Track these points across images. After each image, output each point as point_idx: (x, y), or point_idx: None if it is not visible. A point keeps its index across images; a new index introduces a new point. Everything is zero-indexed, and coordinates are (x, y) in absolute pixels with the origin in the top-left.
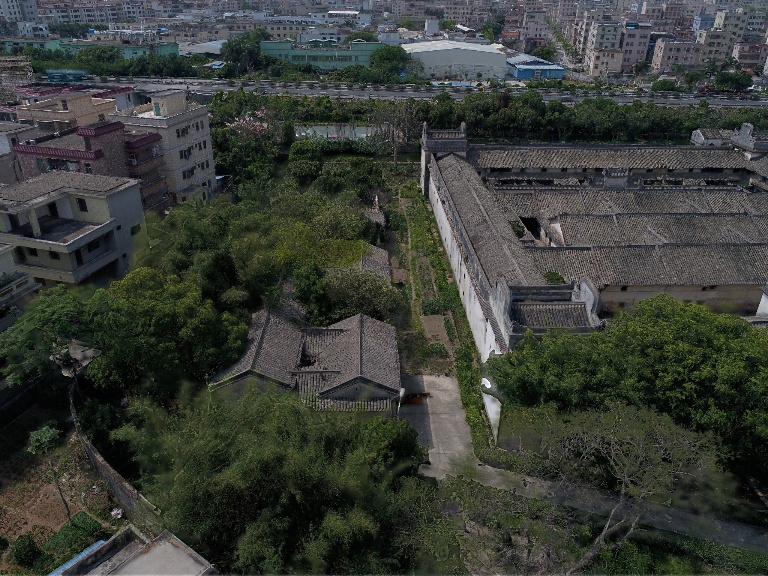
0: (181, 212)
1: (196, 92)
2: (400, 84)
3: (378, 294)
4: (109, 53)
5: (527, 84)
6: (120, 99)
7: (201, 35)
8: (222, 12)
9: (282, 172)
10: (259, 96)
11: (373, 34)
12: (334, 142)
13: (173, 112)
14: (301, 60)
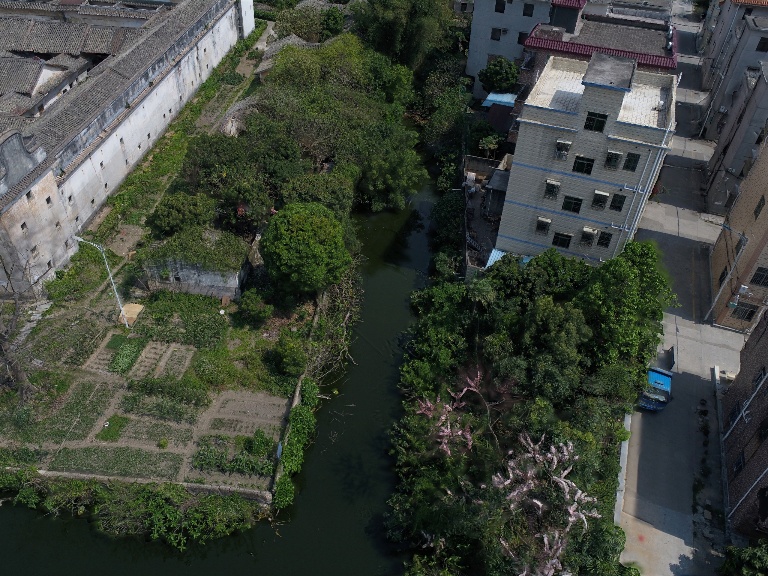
0: (432, 2)
1: None
2: None
3: None
4: None
5: None
6: None
7: None
8: None
9: (368, 492)
10: None
11: None
12: None
13: None
14: None
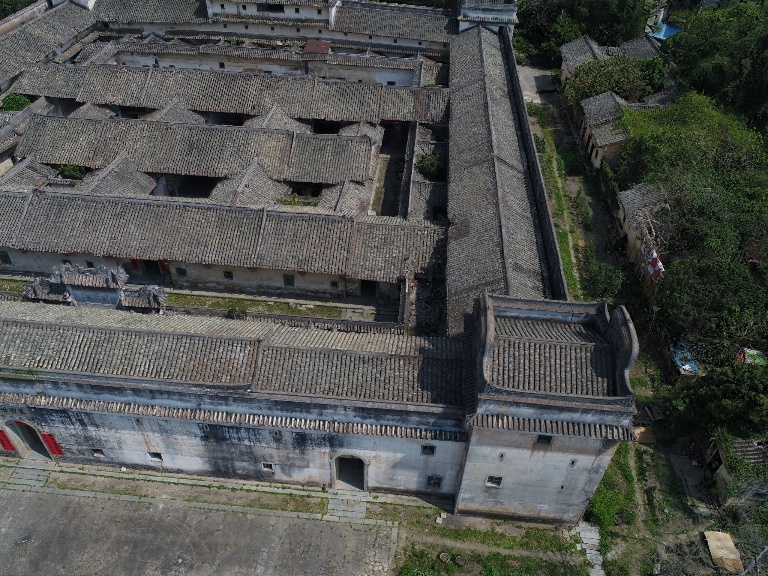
0: None
1: None
2: None
3: None
4: None
5: None
6: None
7: None
8: None
9: None
10: None
11: None
12: None
13: None
14: None
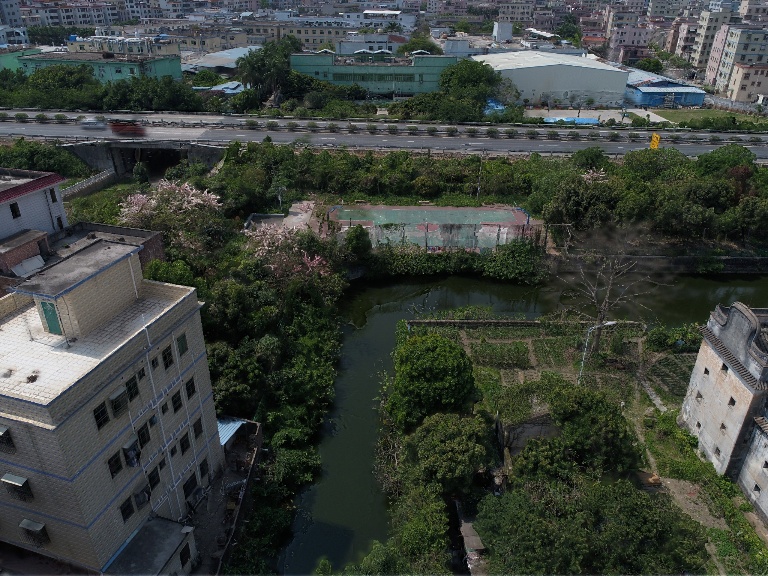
0: None
1: (197, 143)
2: (501, 123)
3: None
4: (76, 75)
5: (664, 116)
6: (31, 202)
7: (212, 42)
8: (239, 11)
9: (355, 341)
10: (296, 149)
11: (435, 42)
12: (438, 255)
13: (99, 318)
14: (345, 80)
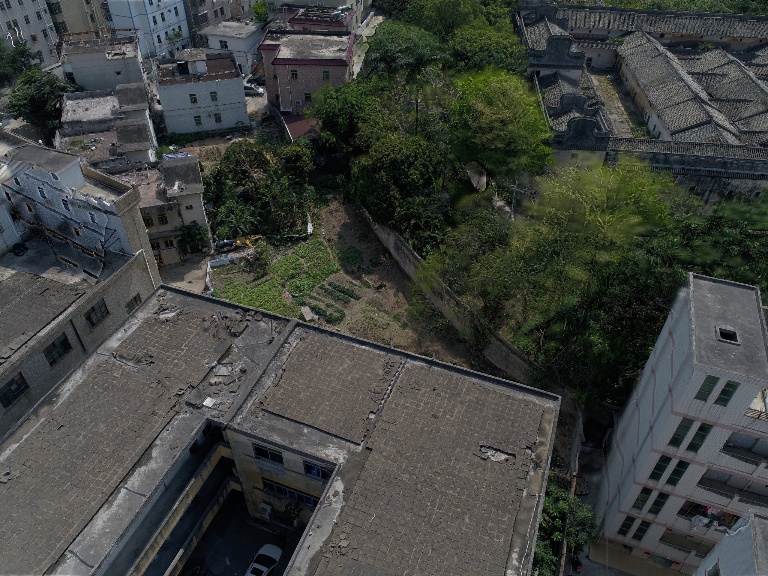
0: None
1: None
2: None
3: (567, 1)
4: None
5: None
6: None
7: None
8: None
9: None
10: None
11: None
12: None
13: None
14: None
